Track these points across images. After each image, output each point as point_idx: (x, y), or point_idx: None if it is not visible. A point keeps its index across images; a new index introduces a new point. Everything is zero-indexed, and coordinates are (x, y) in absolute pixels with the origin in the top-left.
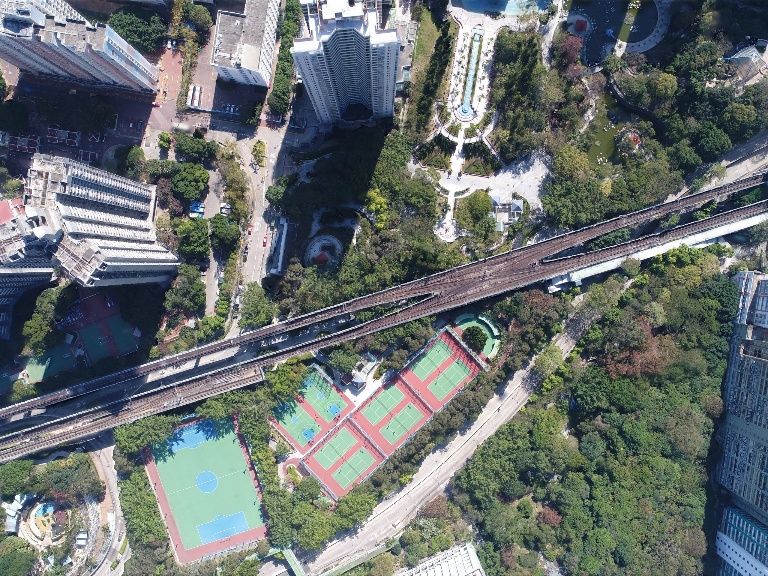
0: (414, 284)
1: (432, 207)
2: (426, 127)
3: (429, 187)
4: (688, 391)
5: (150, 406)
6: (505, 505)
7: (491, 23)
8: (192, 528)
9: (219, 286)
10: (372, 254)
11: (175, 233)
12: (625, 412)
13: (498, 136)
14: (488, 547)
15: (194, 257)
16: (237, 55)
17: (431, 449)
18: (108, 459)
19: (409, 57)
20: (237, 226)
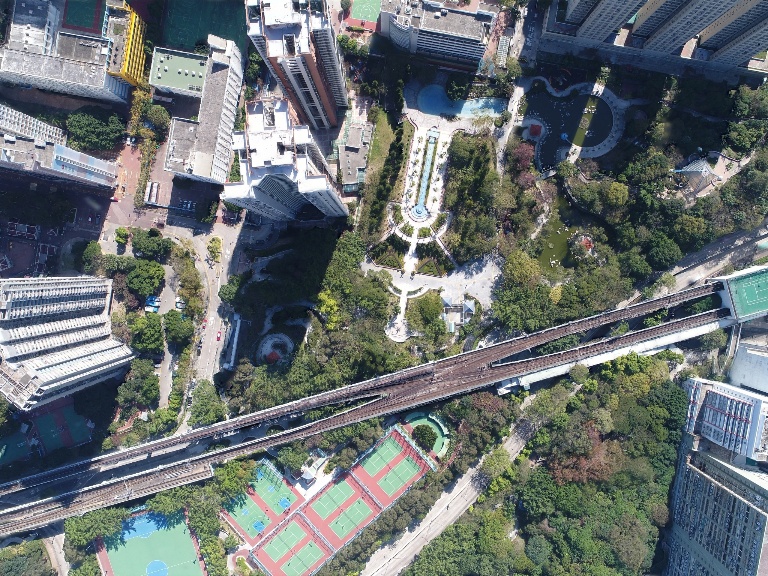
0: (363, 385)
1: (382, 310)
2: (379, 229)
3: (379, 290)
4: (635, 498)
5: (101, 499)
6: None
7: (446, 125)
8: None
9: (173, 379)
10: (321, 356)
11: None
12: (571, 517)
13: (450, 239)
14: None
15: None
16: (189, 162)
17: (380, 544)
18: (61, 546)
19: (364, 159)
20: (191, 322)
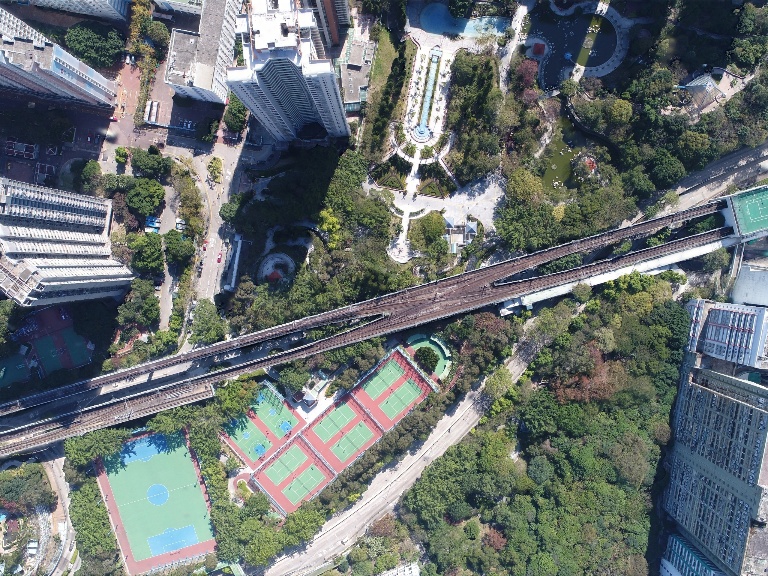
0: (365, 304)
1: (384, 228)
2: (381, 148)
3: (382, 208)
4: (637, 417)
5: (101, 419)
6: (451, 526)
7: (449, 44)
8: (142, 540)
9: (173, 301)
10: (323, 274)
11: (130, 247)
12: (573, 437)
13: (453, 158)
14: (431, 568)
15: (149, 271)
16: (190, 74)
17: (381, 468)
18: (61, 470)
19: (366, 77)
20: (191, 242)
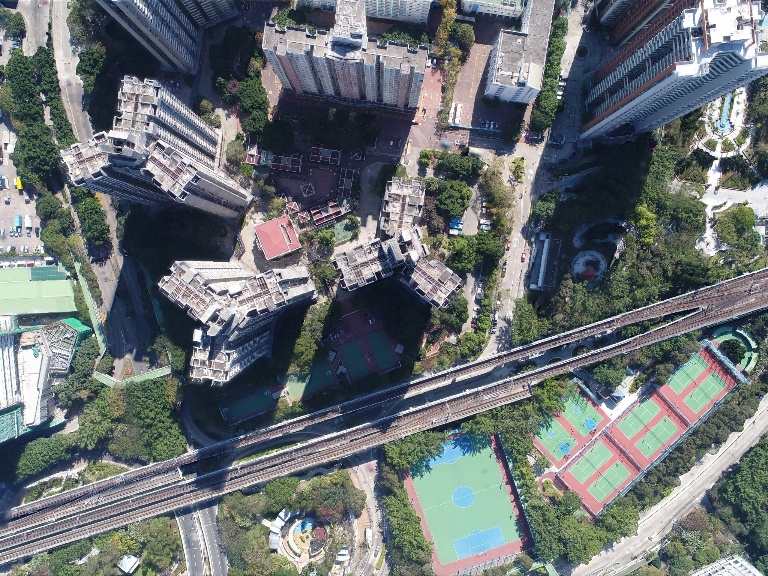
0: (682, 298)
1: (700, 222)
2: (690, 142)
3: (699, 202)
4: None
5: (418, 422)
6: None
7: None
8: (448, 543)
9: (477, 302)
10: (644, 269)
11: None
12: None
13: (762, 150)
14: (767, 560)
15: None
16: (522, 74)
17: None
18: (365, 475)
19: None
20: None
